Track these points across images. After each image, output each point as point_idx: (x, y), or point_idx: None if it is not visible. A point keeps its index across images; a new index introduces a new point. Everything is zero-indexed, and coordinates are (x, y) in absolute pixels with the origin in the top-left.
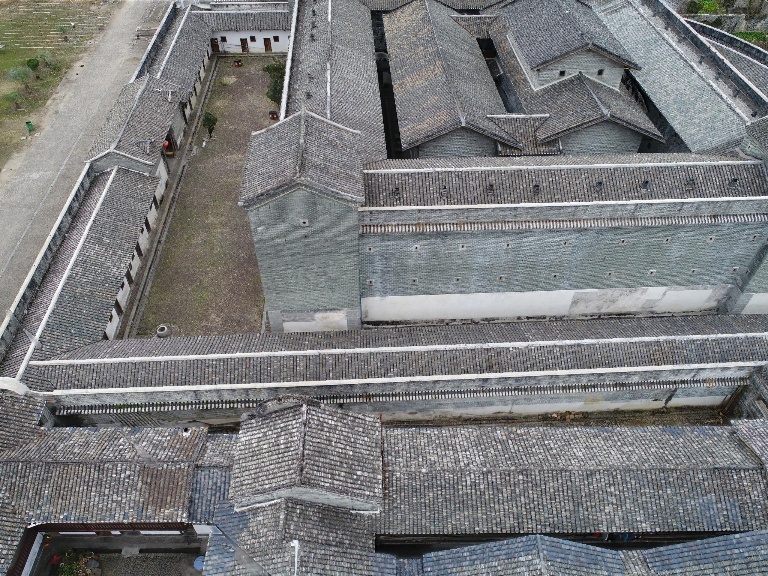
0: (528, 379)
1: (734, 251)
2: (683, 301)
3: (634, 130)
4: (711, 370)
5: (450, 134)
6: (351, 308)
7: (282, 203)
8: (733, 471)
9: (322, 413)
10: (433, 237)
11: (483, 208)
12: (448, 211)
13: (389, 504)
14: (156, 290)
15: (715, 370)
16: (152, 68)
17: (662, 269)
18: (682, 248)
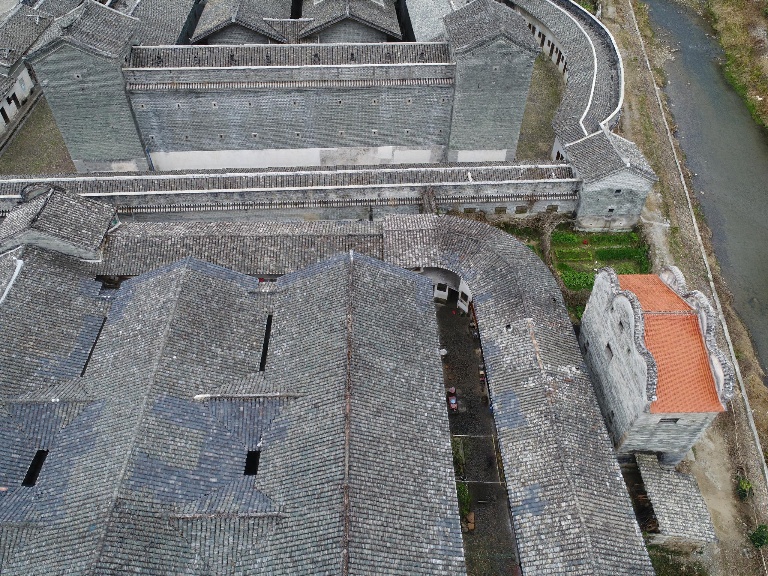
0: (249, 195)
1: (433, 113)
2: (411, 161)
3: (372, 27)
4: (389, 190)
5: (230, 31)
6: (139, 159)
7: (56, 58)
8: (362, 237)
9: (66, 196)
10: (189, 96)
11: (219, 69)
12: (193, 72)
13: (109, 257)
14: (3, 160)
15: (393, 190)
16: (34, 4)
17: (382, 129)
18: (390, 109)
